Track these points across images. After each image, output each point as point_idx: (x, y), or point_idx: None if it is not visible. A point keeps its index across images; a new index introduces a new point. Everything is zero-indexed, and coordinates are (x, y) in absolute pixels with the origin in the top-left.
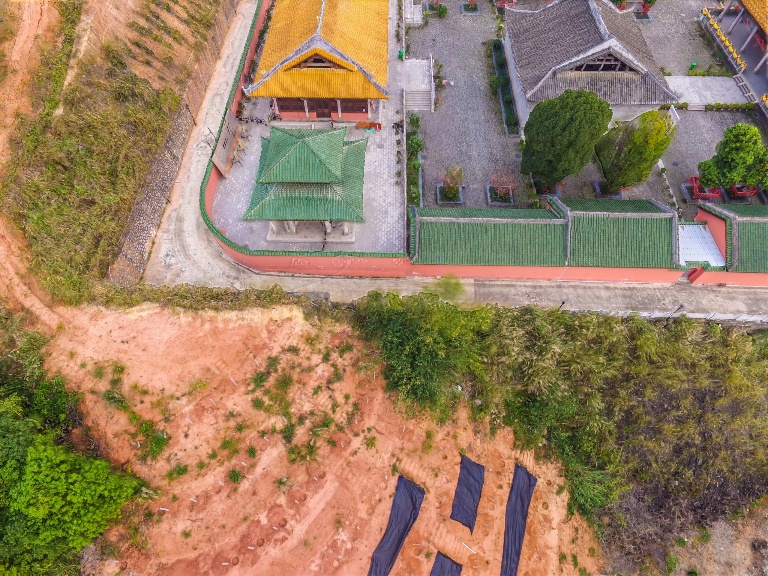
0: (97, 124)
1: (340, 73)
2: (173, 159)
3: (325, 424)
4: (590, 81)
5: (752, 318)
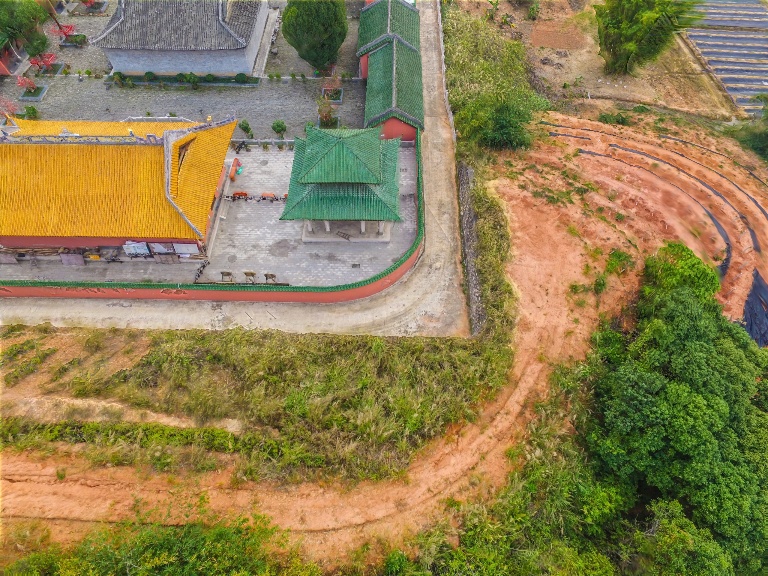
0: (260, 372)
1: (193, 149)
2: None
3: (566, 176)
4: (236, 7)
5: None
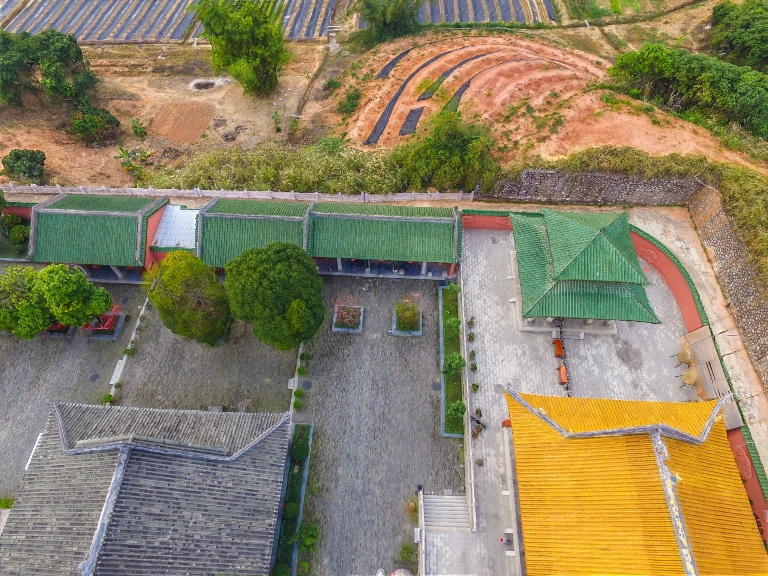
0: None
1: None
2: (762, 349)
3: None
4: None
5: (163, 193)
